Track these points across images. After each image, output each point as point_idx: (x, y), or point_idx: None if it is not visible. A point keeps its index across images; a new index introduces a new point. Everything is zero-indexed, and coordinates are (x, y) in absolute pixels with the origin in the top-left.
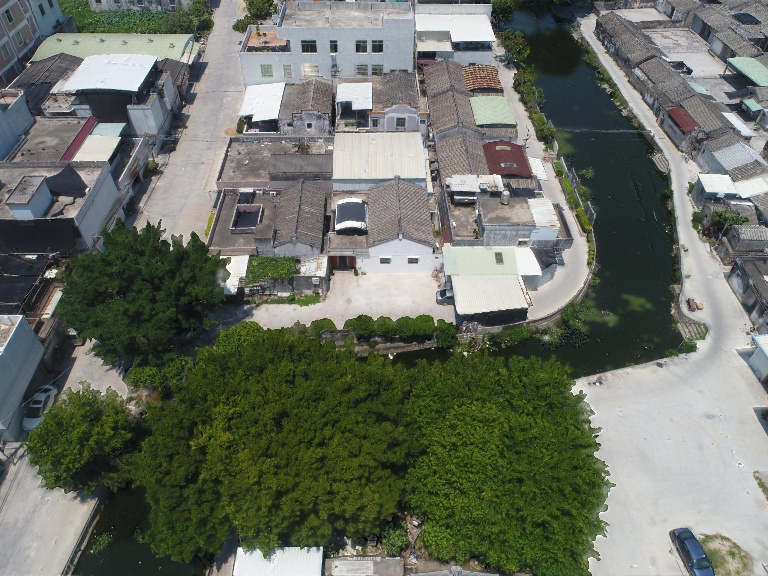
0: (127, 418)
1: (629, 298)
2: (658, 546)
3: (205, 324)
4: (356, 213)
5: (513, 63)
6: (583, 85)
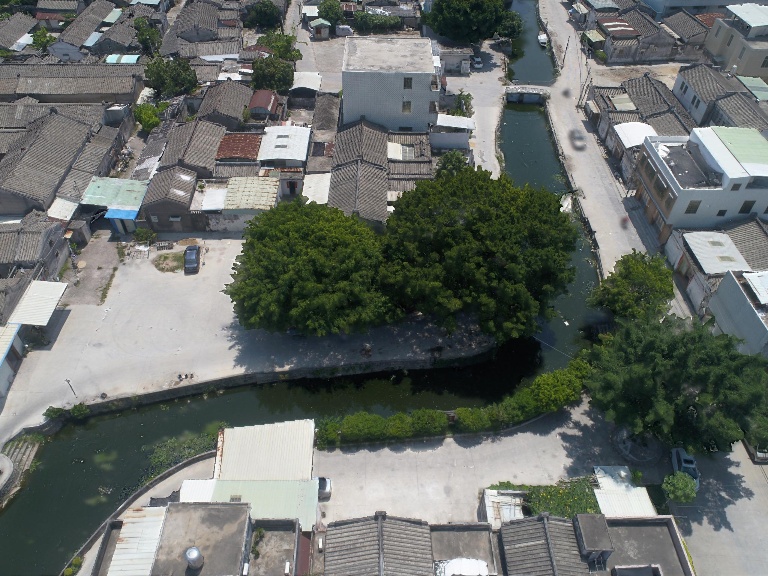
0: (611, 296)
1: (50, 531)
2: (211, 267)
3: None
4: None
5: None
6: None
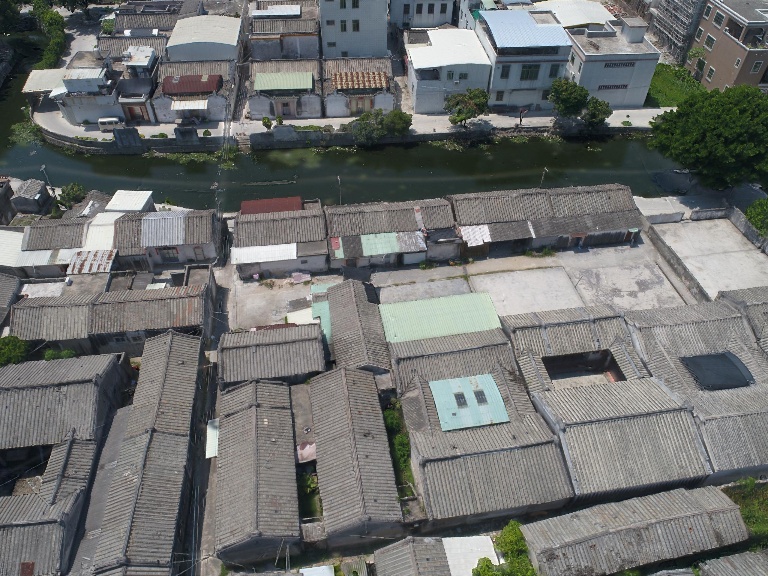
0: None
1: None
2: None
3: (55, 2)
4: (139, 32)
5: (484, 138)
6: (438, 186)
